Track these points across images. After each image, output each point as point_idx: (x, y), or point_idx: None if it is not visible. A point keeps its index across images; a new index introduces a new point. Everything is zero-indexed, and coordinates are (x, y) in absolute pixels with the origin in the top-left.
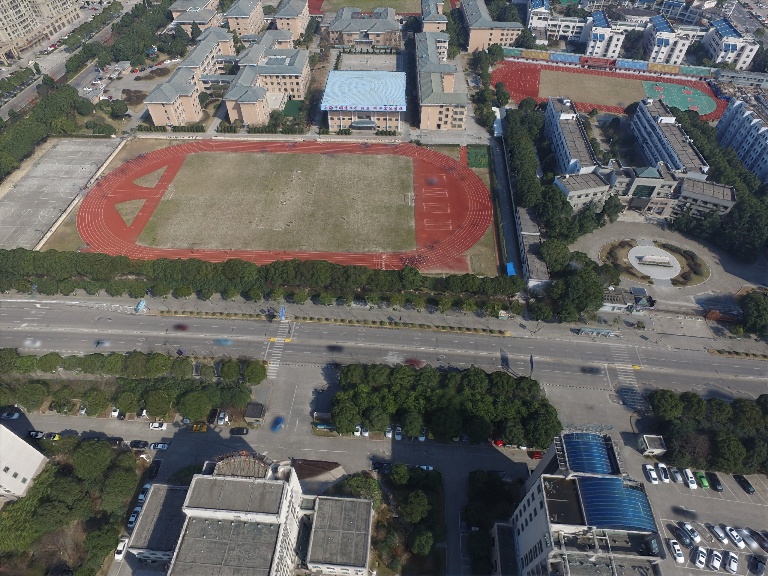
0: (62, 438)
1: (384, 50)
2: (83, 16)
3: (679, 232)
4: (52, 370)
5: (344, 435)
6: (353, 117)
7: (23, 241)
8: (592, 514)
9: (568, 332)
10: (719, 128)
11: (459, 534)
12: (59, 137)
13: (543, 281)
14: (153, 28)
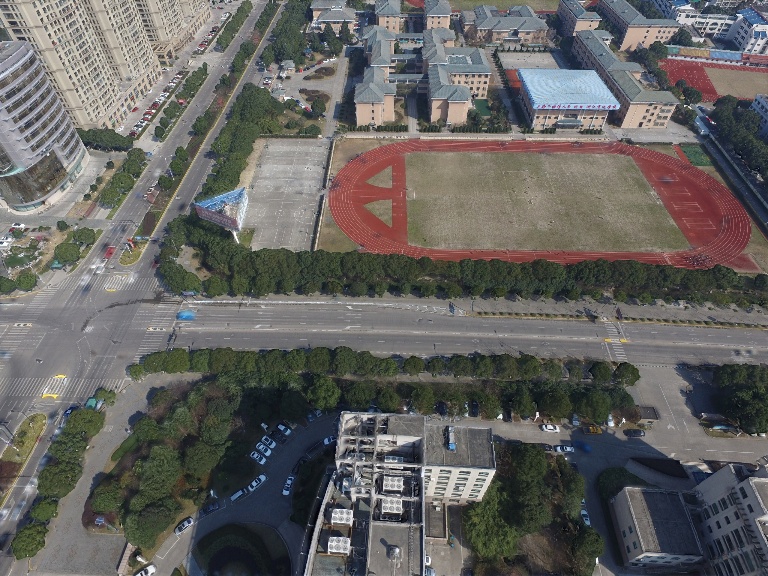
0: None
1: (535, 48)
2: (213, 15)
3: None
4: (418, 373)
5: (742, 436)
6: (560, 116)
7: (294, 243)
8: None
9: None
10: None
11: None
12: (265, 137)
13: None
14: (299, 27)
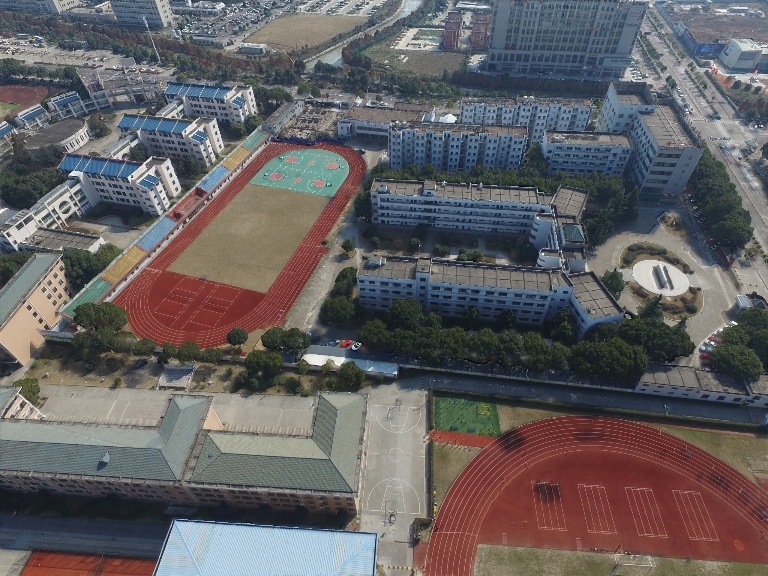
0: None
1: None
2: None
3: (596, 245)
4: None
5: None
6: None
7: None
8: None
9: None
10: (400, 162)
11: None
12: None
13: None
14: None
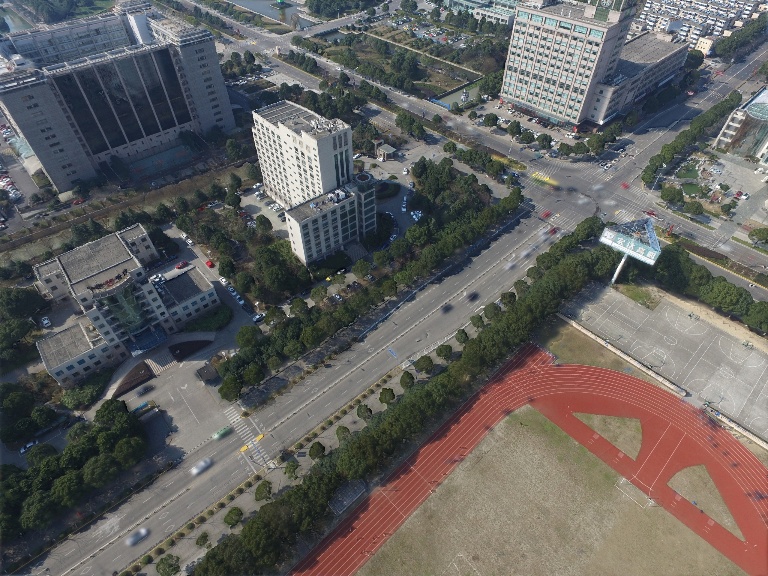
0: (305, 269)
1: None
2: None
3: None
4: None
5: None
6: None
7: (605, 323)
8: None
9: None
10: None
11: None
12: None
13: None
14: None
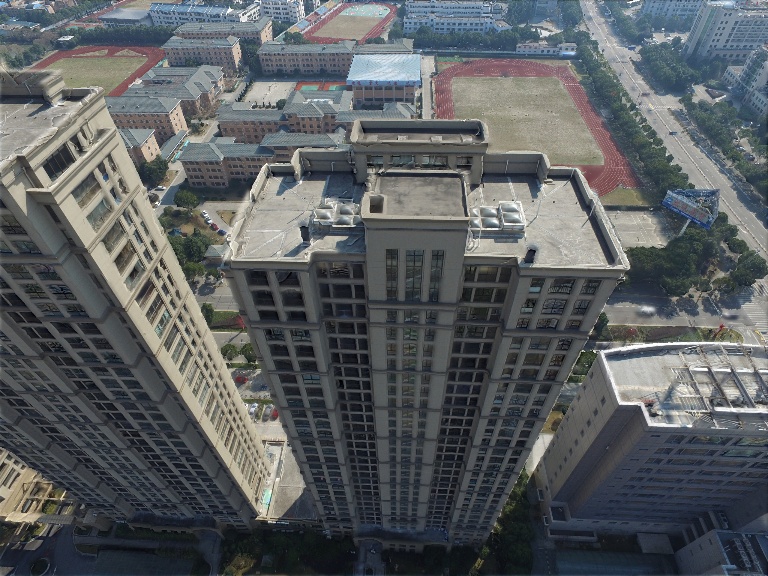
0: None
1: (239, 87)
2: None
3: None
4: None
5: None
6: None
7: (634, 221)
8: (731, 6)
9: None
10: None
11: None
12: None
13: None
14: None
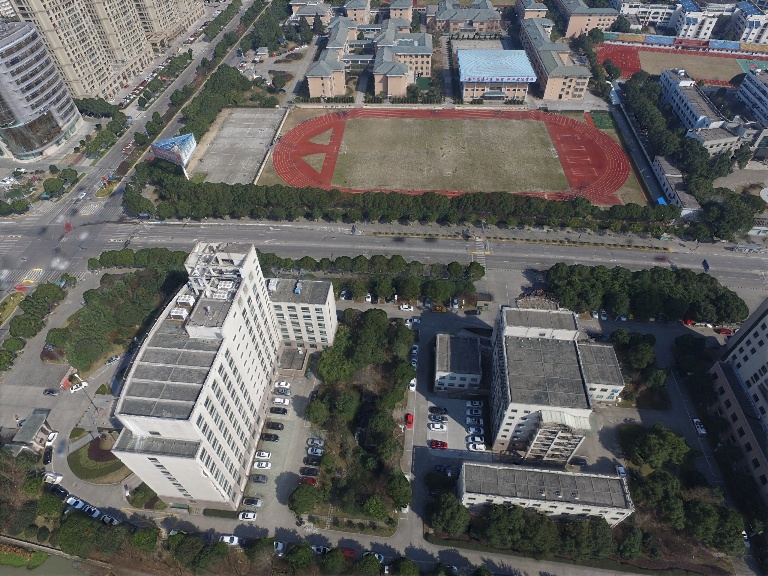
0: (348, 308)
1: (488, 36)
2: (207, 12)
3: None
4: (310, 268)
5: None
6: (486, 88)
7: None
8: None
9: (723, 249)
10: None
11: (674, 381)
12: (231, 107)
13: (696, 210)
14: (278, 20)
